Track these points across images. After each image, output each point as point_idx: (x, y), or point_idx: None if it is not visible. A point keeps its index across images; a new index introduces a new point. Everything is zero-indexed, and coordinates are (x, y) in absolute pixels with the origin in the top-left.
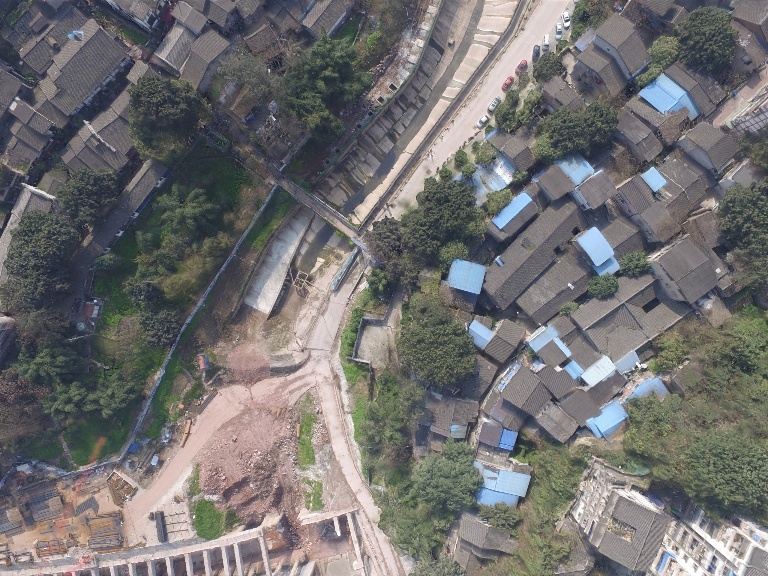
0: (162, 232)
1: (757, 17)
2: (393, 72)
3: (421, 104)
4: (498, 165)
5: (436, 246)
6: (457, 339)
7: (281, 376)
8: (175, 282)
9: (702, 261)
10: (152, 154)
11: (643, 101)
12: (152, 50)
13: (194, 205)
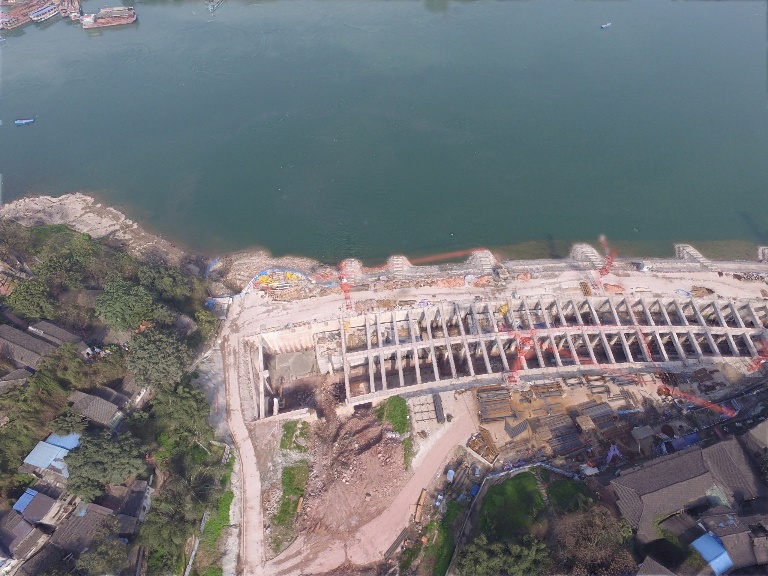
0: None
1: None
2: None
3: None
4: None
5: None
6: None
7: (307, 575)
8: None
9: None
10: None
11: None
12: None
13: None
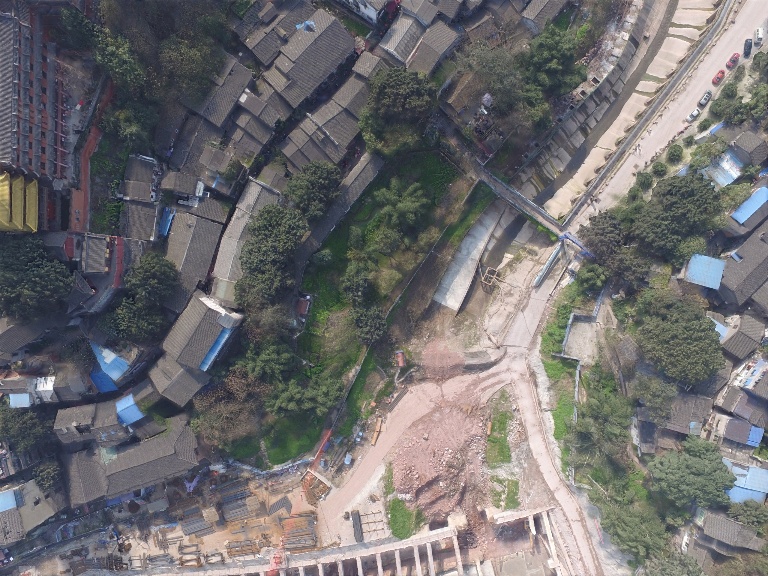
0: (367, 227)
1: None
2: (596, 65)
3: (614, 98)
4: (724, 159)
5: (677, 241)
6: None
7: (473, 373)
8: (393, 278)
9: None
10: (384, 147)
11: None
12: (377, 41)
13: (413, 199)
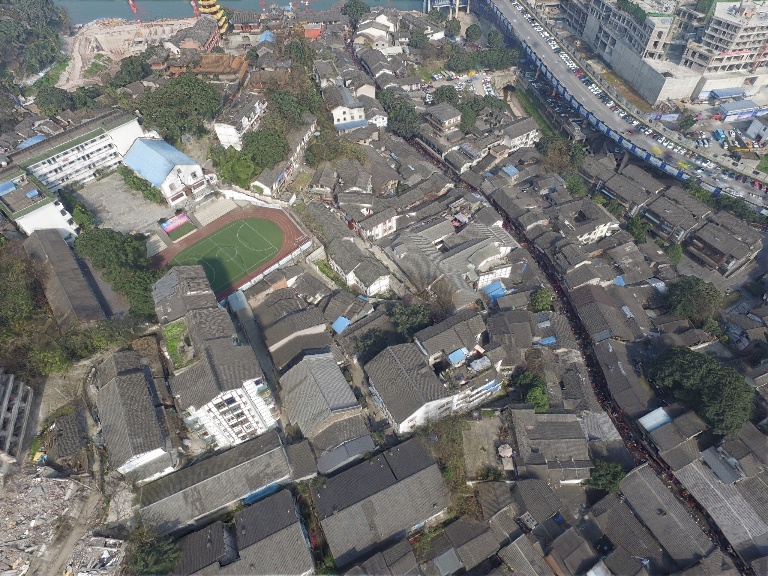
0: None
1: None
2: None
3: None
4: None
5: None
6: None
7: None
8: None
9: None
10: None
11: None
12: None
13: None
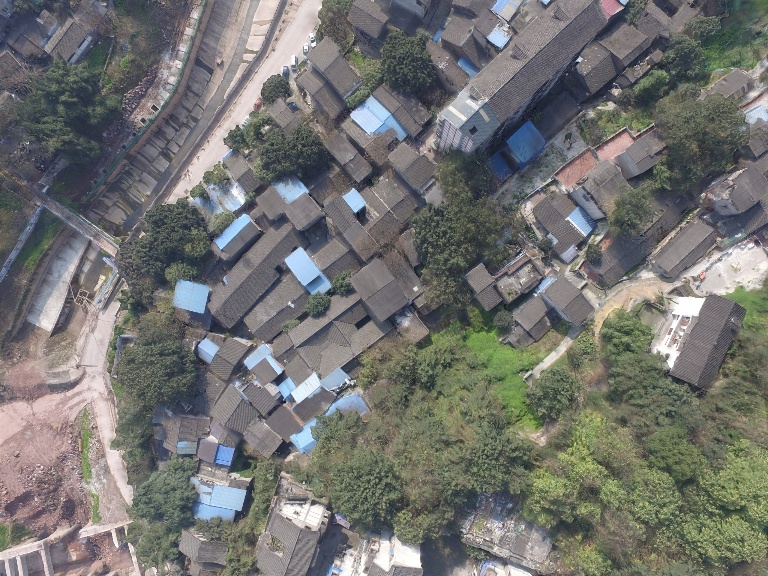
0: None
1: (459, 39)
2: (154, 93)
3: (194, 123)
4: (234, 186)
5: (158, 267)
6: (166, 359)
7: (60, 392)
8: None
9: (388, 281)
10: None
11: (354, 123)
12: None
13: None
